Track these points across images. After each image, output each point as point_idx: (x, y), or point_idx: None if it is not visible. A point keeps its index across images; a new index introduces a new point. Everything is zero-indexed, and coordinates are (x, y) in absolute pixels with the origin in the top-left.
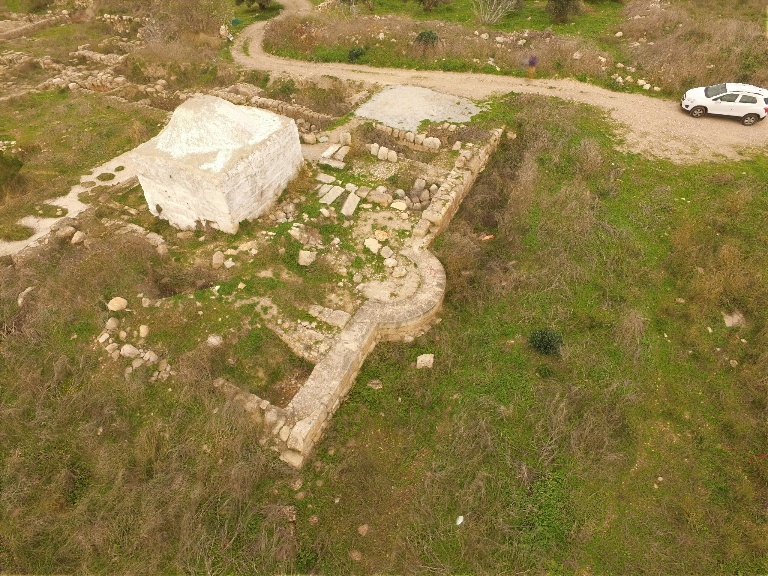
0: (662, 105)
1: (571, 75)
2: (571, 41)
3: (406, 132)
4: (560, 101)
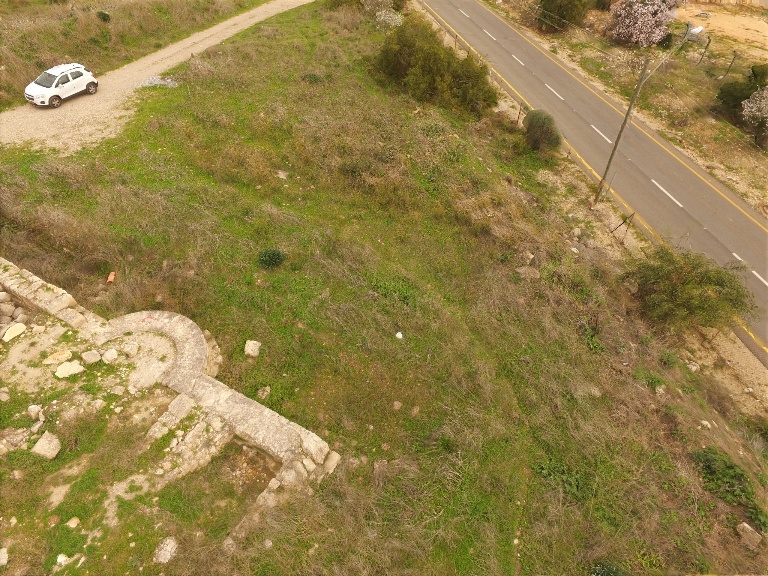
0: (19, 114)
1: None
2: None
3: None
4: None
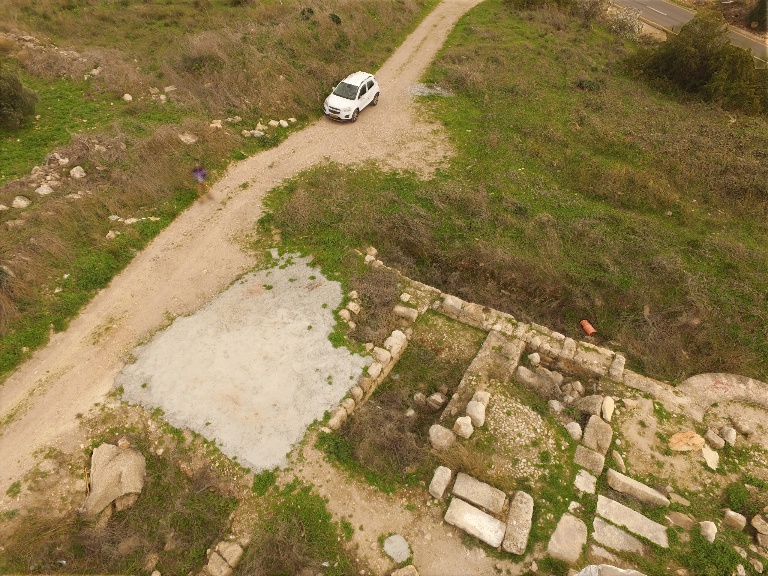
0: (323, 129)
1: (226, 161)
2: (161, 128)
3: (366, 375)
4: (292, 188)
